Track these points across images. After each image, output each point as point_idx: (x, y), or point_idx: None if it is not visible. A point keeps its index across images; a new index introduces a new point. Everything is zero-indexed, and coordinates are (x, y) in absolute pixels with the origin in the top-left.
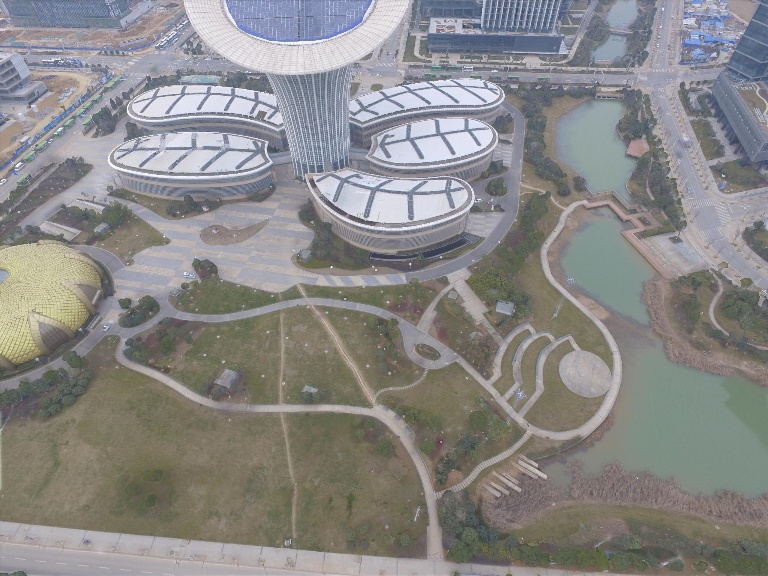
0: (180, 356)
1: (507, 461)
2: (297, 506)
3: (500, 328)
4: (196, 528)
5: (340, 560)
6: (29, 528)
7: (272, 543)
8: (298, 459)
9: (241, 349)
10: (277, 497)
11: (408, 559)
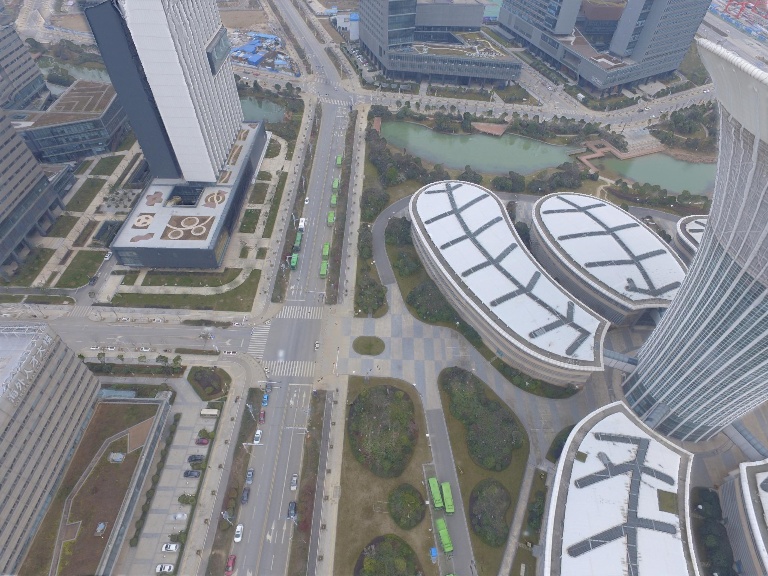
0: None
1: None
2: None
3: None
4: None
5: None
6: None
7: None
8: None
9: None
10: None
11: None
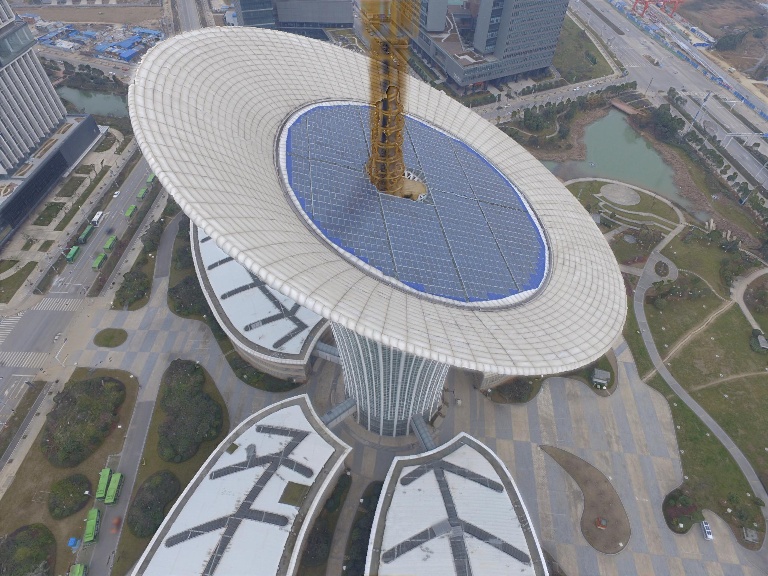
0: None
1: None
2: None
3: (612, 226)
4: None
5: None
6: None
7: None
8: None
9: (764, 418)
10: None
11: None
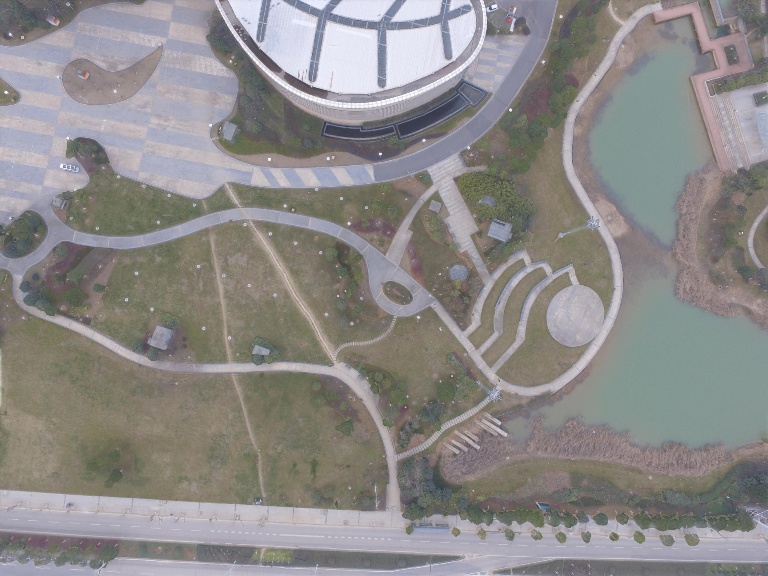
0: (96, 302)
1: (471, 420)
2: (263, 471)
3: (489, 259)
4: (169, 491)
5: (308, 513)
6: (8, 493)
7: (244, 501)
8: (258, 426)
9: (169, 292)
10: (242, 463)
11: (369, 512)
